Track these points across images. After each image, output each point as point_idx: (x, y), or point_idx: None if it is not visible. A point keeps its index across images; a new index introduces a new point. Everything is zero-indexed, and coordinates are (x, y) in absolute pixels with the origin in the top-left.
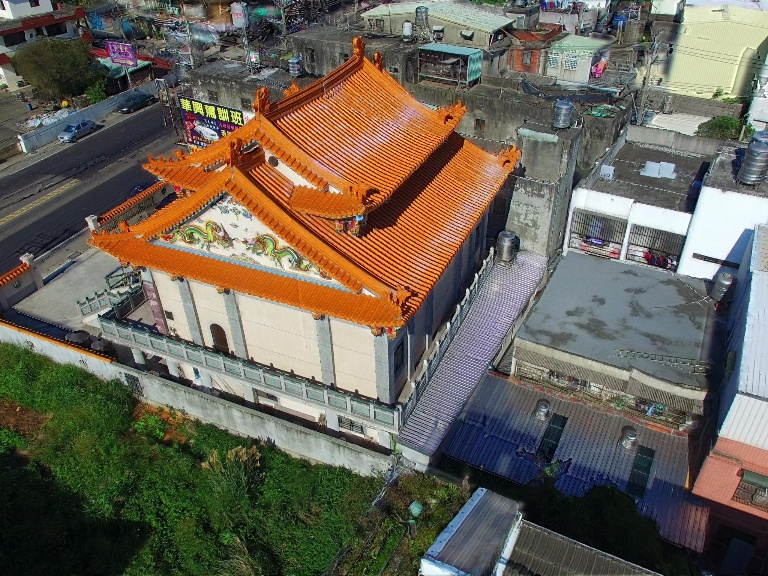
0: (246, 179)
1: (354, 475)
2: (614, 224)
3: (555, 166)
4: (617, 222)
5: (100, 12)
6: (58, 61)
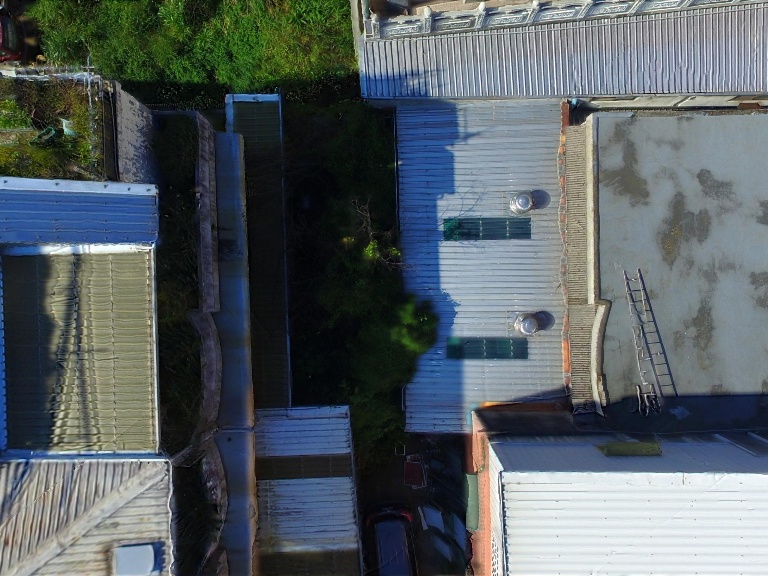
0: None
1: (349, 20)
2: None
3: None
4: None
5: None
6: None
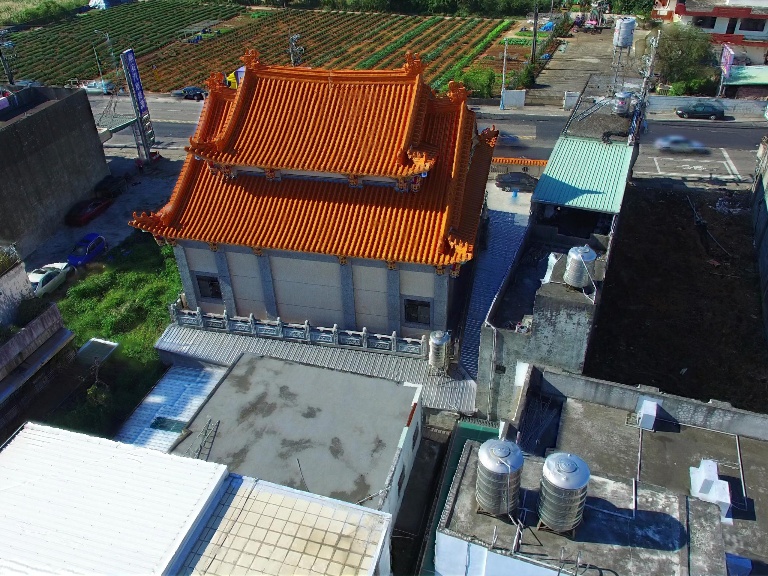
0: (208, 101)
1: None
2: None
3: None
4: None
5: None
6: None
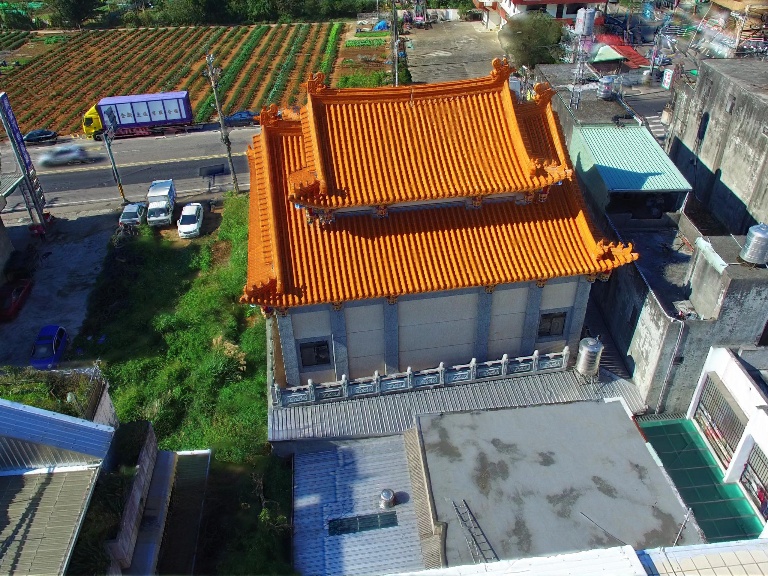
0: (264, 139)
1: None
2: (736, 421)
3: (712, 304)
4: (739, 420)
5: (624, 1)
6: (531, 35)
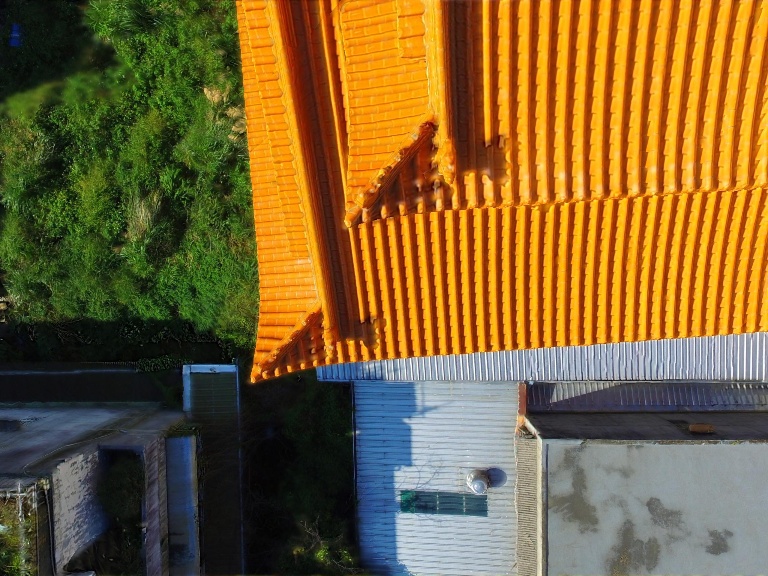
0: None
1: None
2: None
3: None
4: None
5: None
6: None
